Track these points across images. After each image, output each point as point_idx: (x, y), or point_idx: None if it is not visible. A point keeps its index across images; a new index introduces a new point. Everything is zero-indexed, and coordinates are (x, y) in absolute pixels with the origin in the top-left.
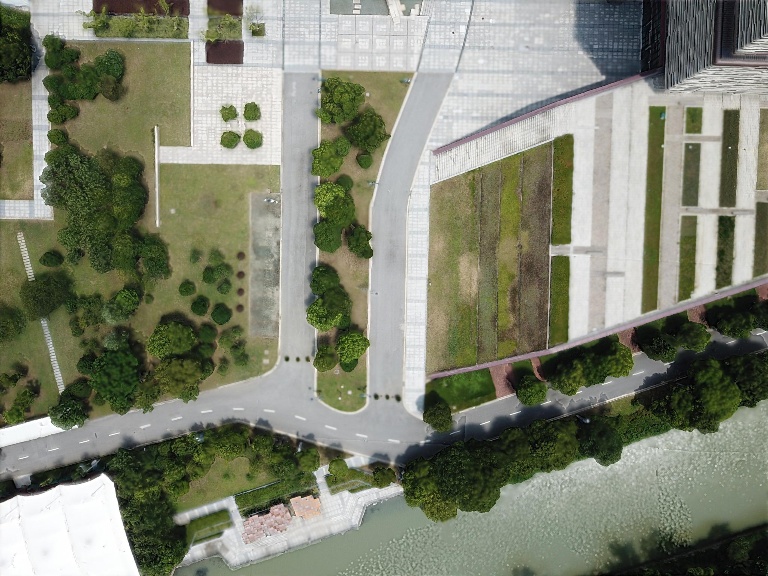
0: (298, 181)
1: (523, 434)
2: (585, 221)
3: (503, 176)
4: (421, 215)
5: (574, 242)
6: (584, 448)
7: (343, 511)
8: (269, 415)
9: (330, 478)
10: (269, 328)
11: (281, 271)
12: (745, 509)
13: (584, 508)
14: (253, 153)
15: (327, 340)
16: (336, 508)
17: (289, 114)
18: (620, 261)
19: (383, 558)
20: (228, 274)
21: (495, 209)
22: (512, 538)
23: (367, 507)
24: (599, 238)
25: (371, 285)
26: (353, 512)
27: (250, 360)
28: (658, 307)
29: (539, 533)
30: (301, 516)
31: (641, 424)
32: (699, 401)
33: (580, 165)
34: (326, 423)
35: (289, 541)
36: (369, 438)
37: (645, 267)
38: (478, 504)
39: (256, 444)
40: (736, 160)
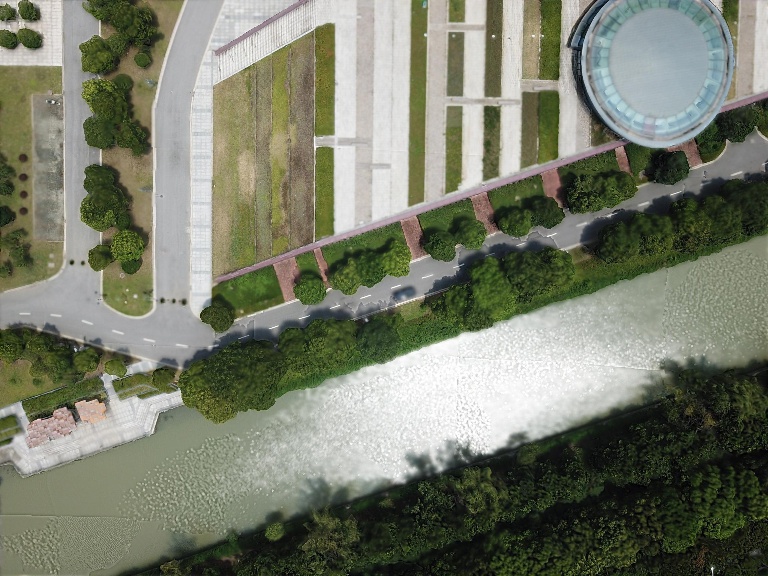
0: (80, 82)
1: (301, 334)
2: (349, 112)
3: (274, 70)
4: (204, 116)
5: (339, 133)
6: (360, 346)
7: (134, 417)
8: (56, 320)
9: (117, 383)
10: (54, 231)
11: (65, 174)
12: (545, 417)
13: (386, 418)
14: (34, 54)
15: (111, 243)
16: (126, 414)
17: (69, 14)
18: (386, 153)
19: (182, 468)
20: (7, 175)
21: (268, 105)
22: (309, 447)
23: (161, 415)
24: (364, 129)
25: (156, 187)
26: (145, 419)
27: (35, 264)
28: (425, 199)
29: (337, 442)
30: (86, 420)
31: (430, 327)
32: (471, 296)
33: (343, 55)
34: (113, 328)
35: (81, 449)
36: (157, 343)
37: (411, 159)
38: (244, 399)
39: (30, 343)
40: (500, 49)
